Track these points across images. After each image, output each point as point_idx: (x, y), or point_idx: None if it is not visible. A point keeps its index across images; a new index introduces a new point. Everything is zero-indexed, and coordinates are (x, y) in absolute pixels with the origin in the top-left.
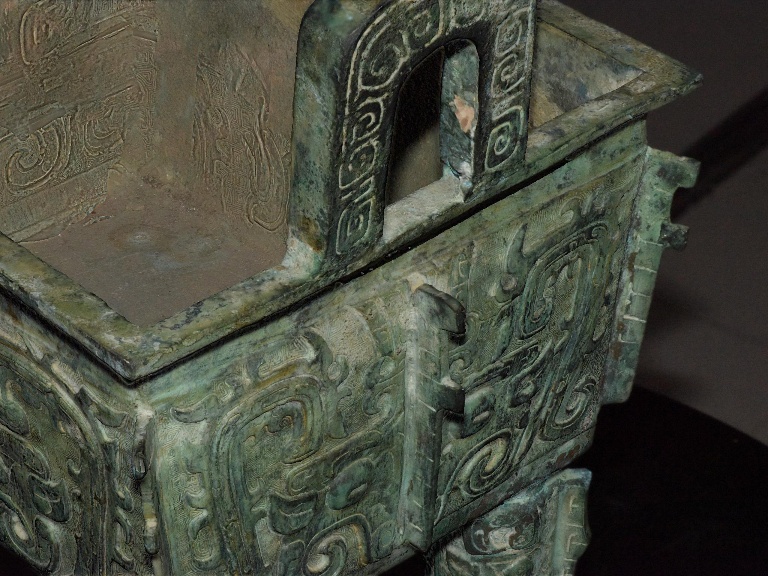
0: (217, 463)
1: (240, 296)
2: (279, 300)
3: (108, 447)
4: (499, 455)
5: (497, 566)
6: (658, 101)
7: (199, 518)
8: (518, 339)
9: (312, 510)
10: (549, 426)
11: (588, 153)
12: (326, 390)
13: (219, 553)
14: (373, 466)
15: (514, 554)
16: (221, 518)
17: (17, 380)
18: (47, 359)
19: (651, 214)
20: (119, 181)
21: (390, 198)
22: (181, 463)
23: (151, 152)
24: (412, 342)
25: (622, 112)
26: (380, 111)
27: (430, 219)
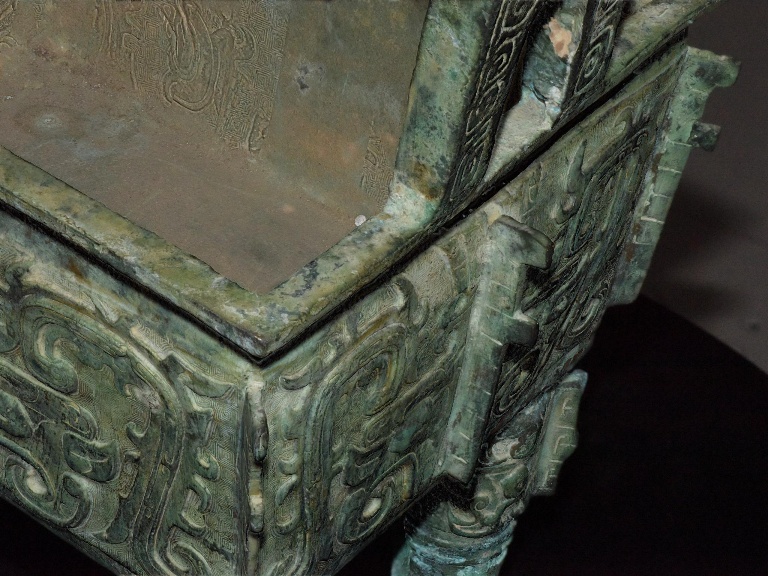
0: (314, 427)
1: (354, 253)
2: (394, 255)
3: (198, 417)
4: (525, 372)
5: (495, 477)
6: (715, 3)
7: (288, 484)
8: (565, 257)
9: (379, 458)
10: (567, 336)
11: None
12: (410, 336)
13: (299, 515)
14: (432, 404)
15: (513, 464)
16: (306, 480)
17: (74, 340)
18: (125, 322)
19: (683, 115)
20: (10, 55)
21: (349, 83)
22: (280, 431)
23: (42, 22)
24: (482, 275)
25: (684, 18)
26: (511, 50)
27: (522, 151)
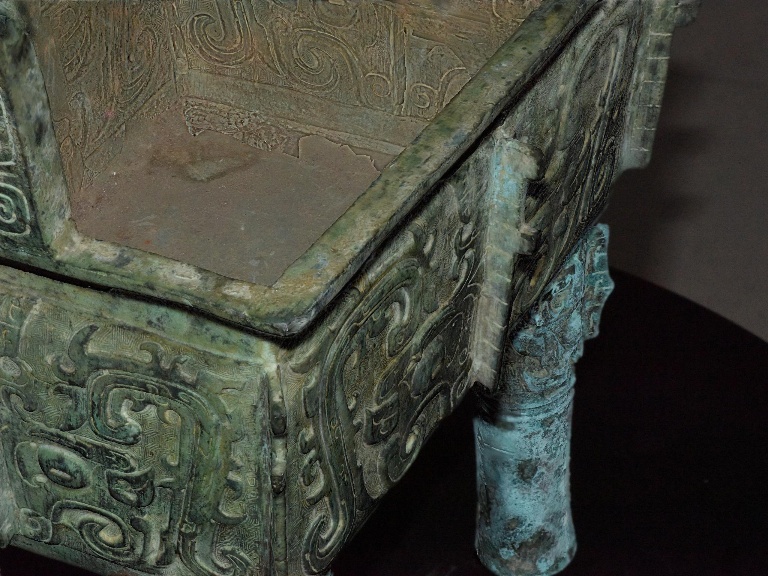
0: None
1: None
2: None
3: None
4: None
5: None
6: (223, 311)
7: None
8: None
9: None
10: None
11: (191, 316)
12: None
13: None
14: None
15: None
16: None
17: None
18: None
19: None
20: None
21: None
22: None
23: None
24: None
25: (181, 291)
26: None
27: None
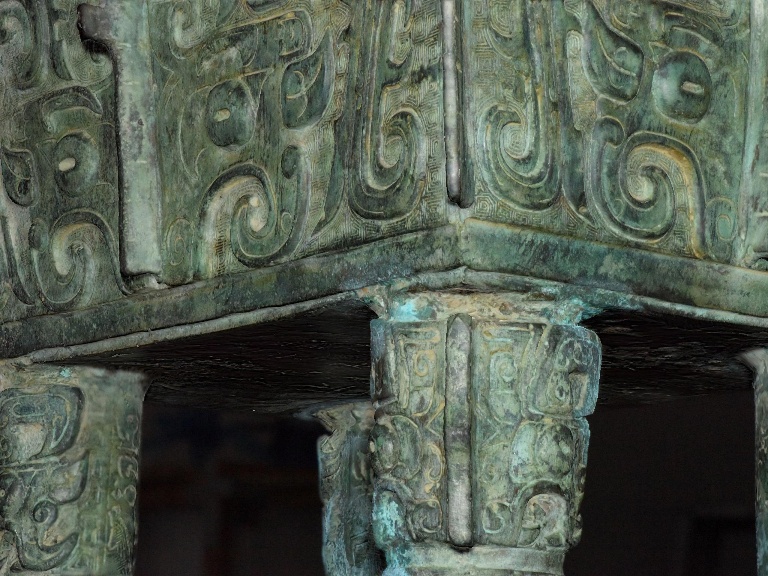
0: None
1: None
2: None
3: None
4: None
5: None
6: None
7: None
8: None
9: (636, 76)
10: None
11: None
12: None
13: (521, 36)
14: (711, 82)
15: None
16: None
17: None
18: None
19: None
20: None
21: None
22: None
23: None
24: None
25: None
26: None
27: None
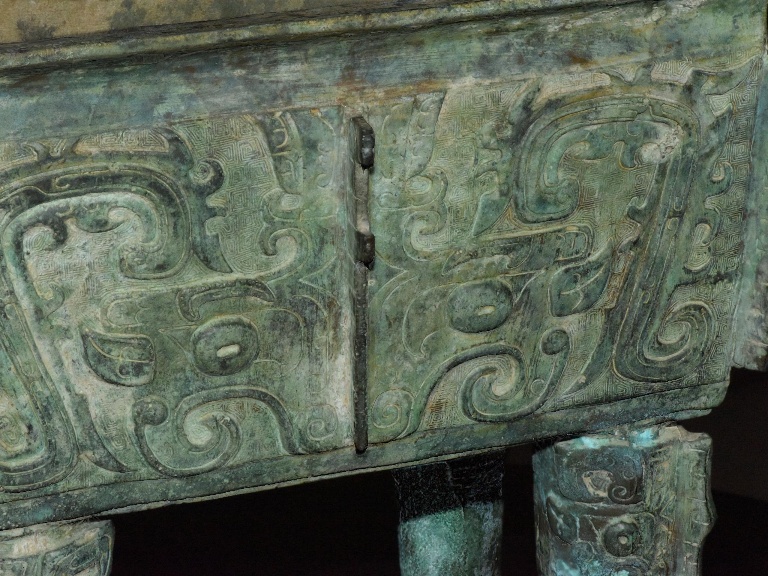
0: None
1: None
2: None
3: (721, 121)
4: None
5: None
6: None
7: None
8: None
9: None
10: None
11: None
12: None
13: None
14: None
15: None
16: None
17: (587, 136)
18: (645, 71)
19: None
20: None
21: None
22: None
23: None
24: None
25: None
26: None
27: None
